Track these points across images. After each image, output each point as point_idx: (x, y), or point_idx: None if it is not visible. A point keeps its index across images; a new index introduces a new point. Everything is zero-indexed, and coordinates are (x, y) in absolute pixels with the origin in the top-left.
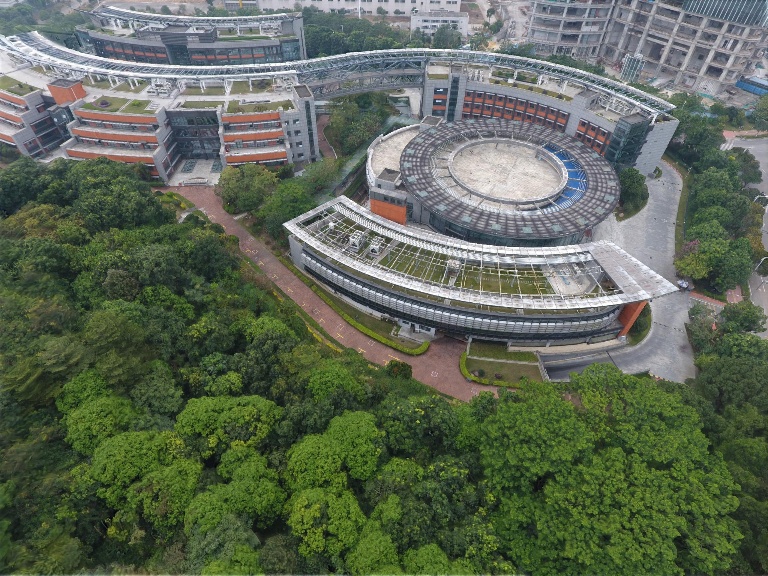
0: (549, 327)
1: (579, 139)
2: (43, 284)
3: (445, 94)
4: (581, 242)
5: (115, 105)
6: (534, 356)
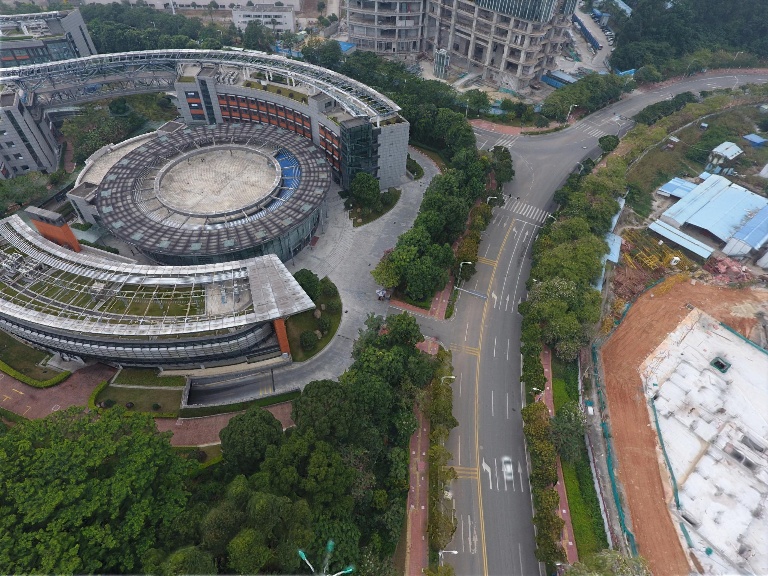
0: (179, 351)
1: (323, 143)
2: None
3: (198, 98)
4: (301, 252)
5: None
6: (183, 380)
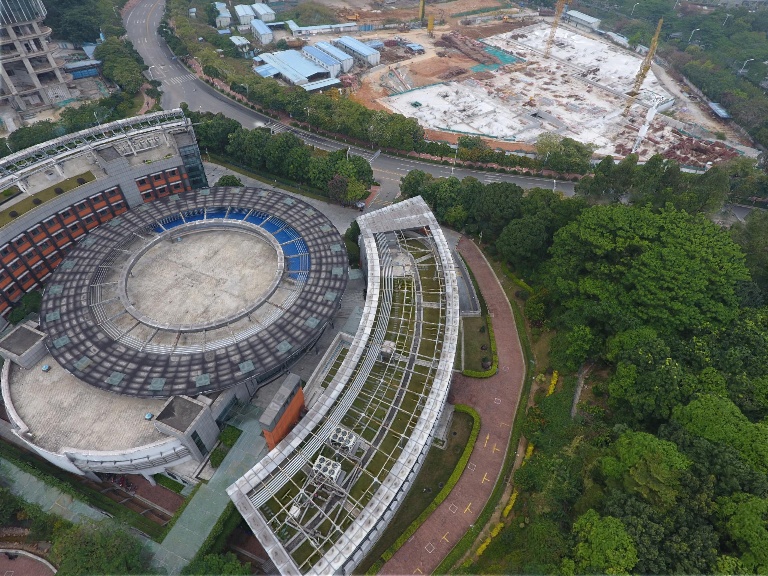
0: None
1: (151, 198)
2: None
3: None
4: None
5: None
6: None
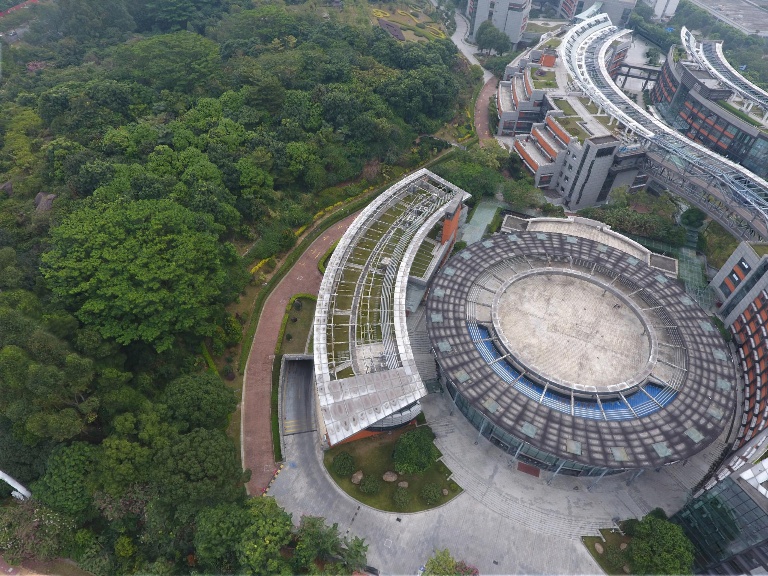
0: None
1: None
2: (316, 74)
3: None
4: (503, 451)
5: (543, 78)
6: None
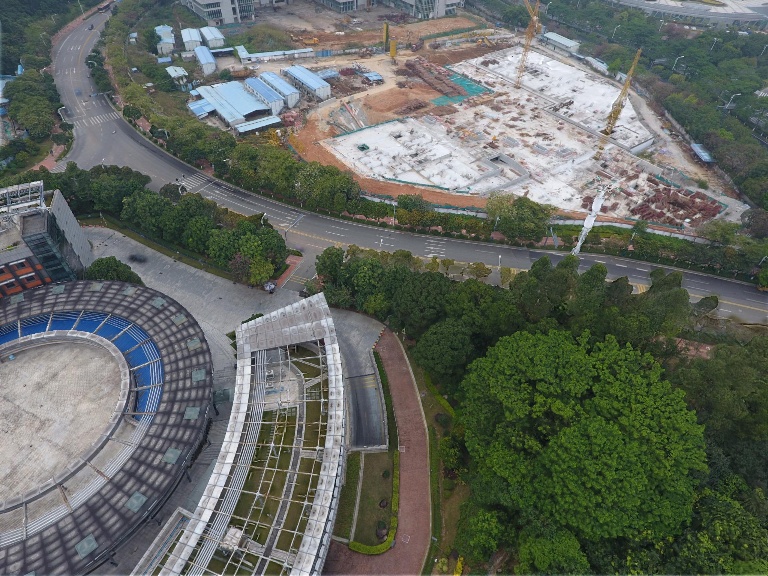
0: None
1: None
2: None
3: None
4: None
5: None
6: (353, 455)
